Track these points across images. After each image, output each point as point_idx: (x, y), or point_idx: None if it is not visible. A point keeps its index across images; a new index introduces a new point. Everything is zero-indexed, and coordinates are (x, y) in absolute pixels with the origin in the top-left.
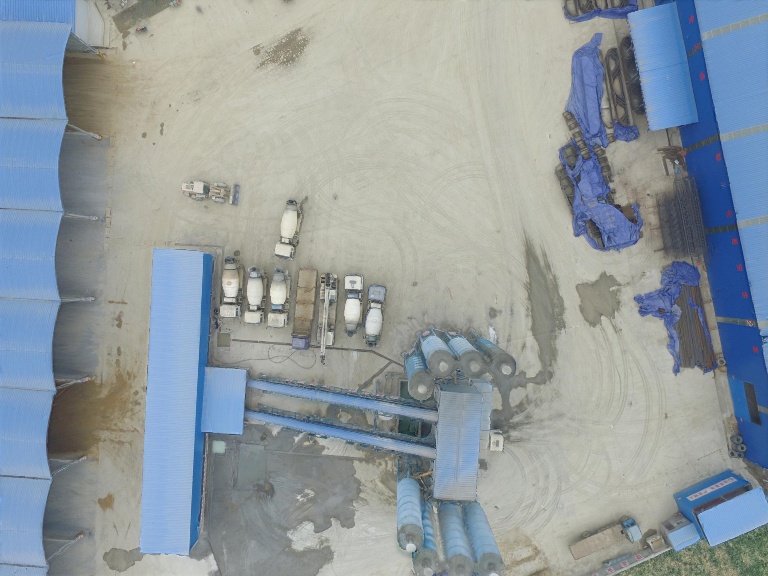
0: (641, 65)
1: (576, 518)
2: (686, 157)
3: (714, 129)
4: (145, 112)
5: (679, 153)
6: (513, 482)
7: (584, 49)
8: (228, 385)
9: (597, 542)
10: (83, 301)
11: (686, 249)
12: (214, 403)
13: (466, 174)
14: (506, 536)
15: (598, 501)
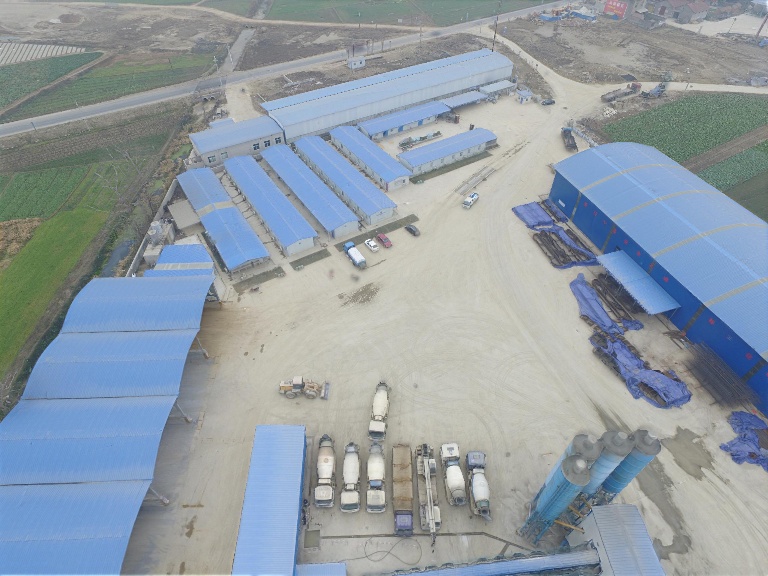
0: (621, 280)
1: None
2: (687, 336)
3: (696, 305)
4: (249, 338)
5: (680, 334)
6: None
7: (575, 281)
8: None
9: None
10: (153, 508)
11: (735, 393)
12: None
13: (522, 360)
14: None
15: None
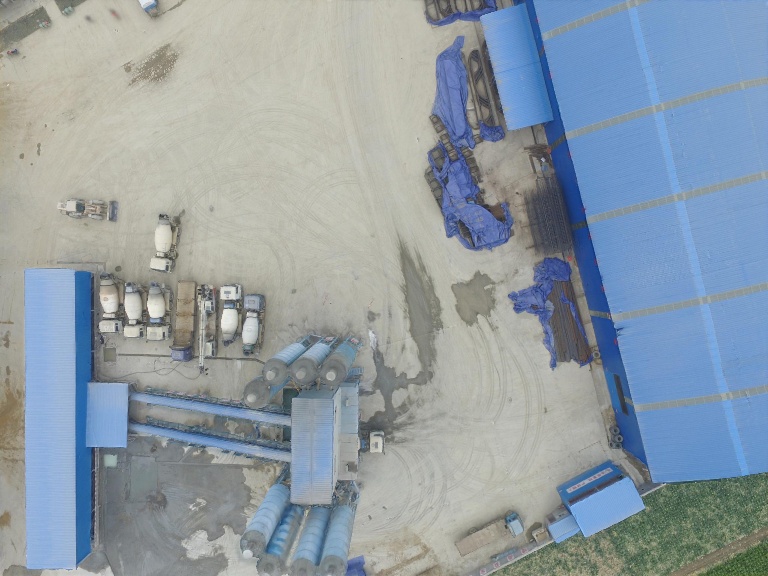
0: (495, 66)
1: (463, 515)
2: (552, 154)
3: None
4: (21, 133)
5: (545, 151)
6: (399, 482)
7: (447, 52)
8: (111, 399)
9: (482, 538)
10: None
11: (551, 245)
12: (98, 418)
13: (338, 181)
14: (395, 536)
15: (483, 497)
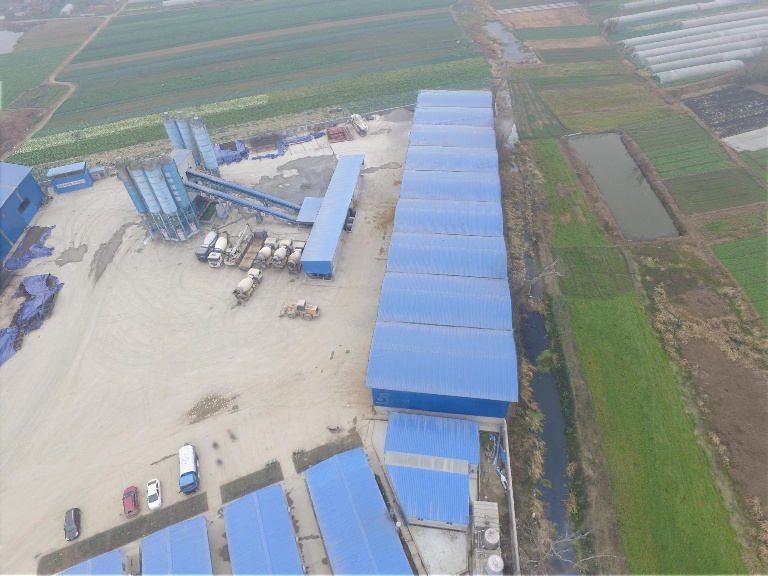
0: None
1: None
2: None
3: None
4: (344, 368)
5: None
6: None
7: None
8: (309, 215)
9: None
10: None
11: (2, 265)
12: None
13: (113, 318)
14: None
15: None
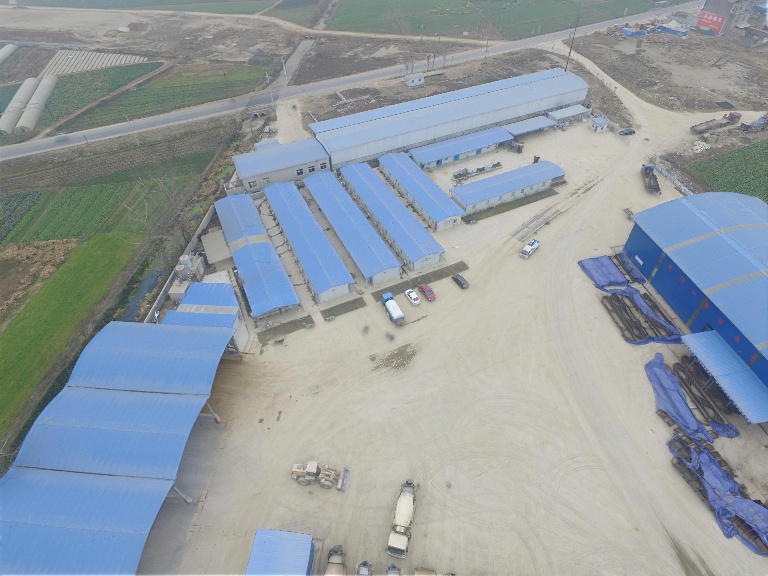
0: (712, 371)
1: None
2: None
3: None
4: (267, 401)
5: None
6: None
7: (652, 363)
8: None
9: None
10: None
11: None
12: None
13: (581, 465)
14: None
15: None
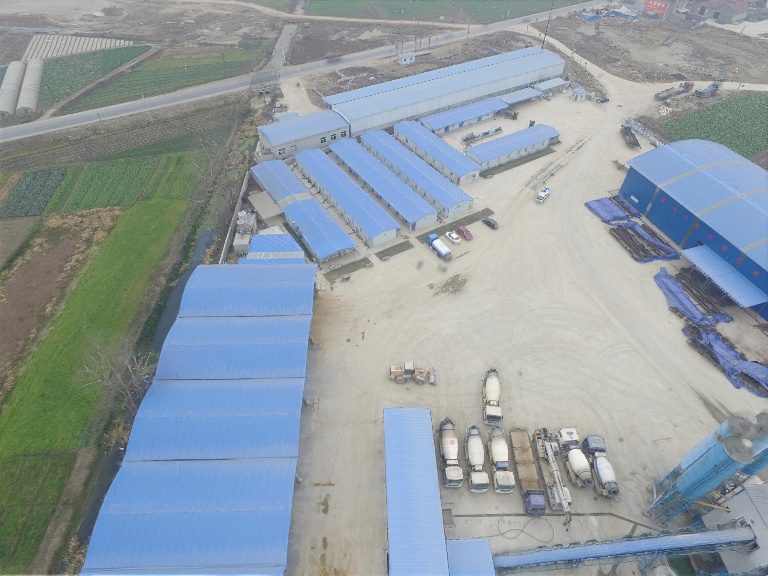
0: (708, 274)
1: None
2: None
3: None
4: (349, 326)
5: None
6: None
7: (659, 275)
8: (471, 561)
9: None
10: None
11: None
12: None
13: (620, 350)
14: None
15: None
